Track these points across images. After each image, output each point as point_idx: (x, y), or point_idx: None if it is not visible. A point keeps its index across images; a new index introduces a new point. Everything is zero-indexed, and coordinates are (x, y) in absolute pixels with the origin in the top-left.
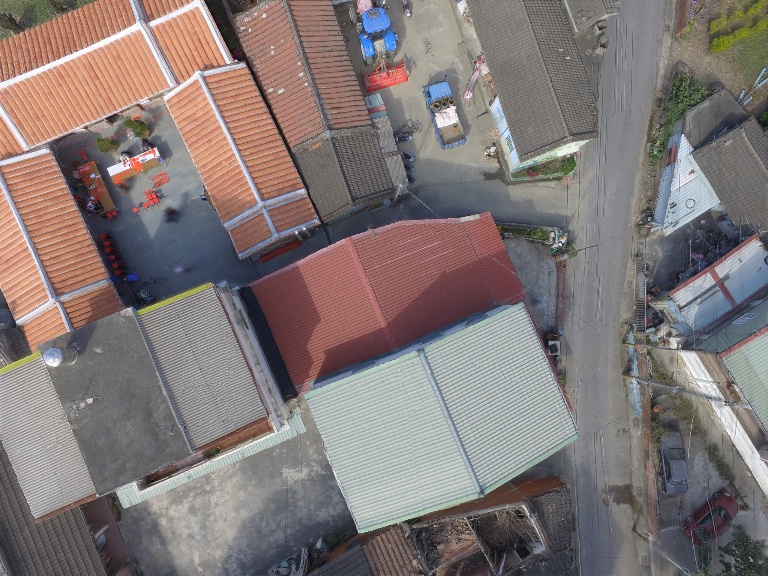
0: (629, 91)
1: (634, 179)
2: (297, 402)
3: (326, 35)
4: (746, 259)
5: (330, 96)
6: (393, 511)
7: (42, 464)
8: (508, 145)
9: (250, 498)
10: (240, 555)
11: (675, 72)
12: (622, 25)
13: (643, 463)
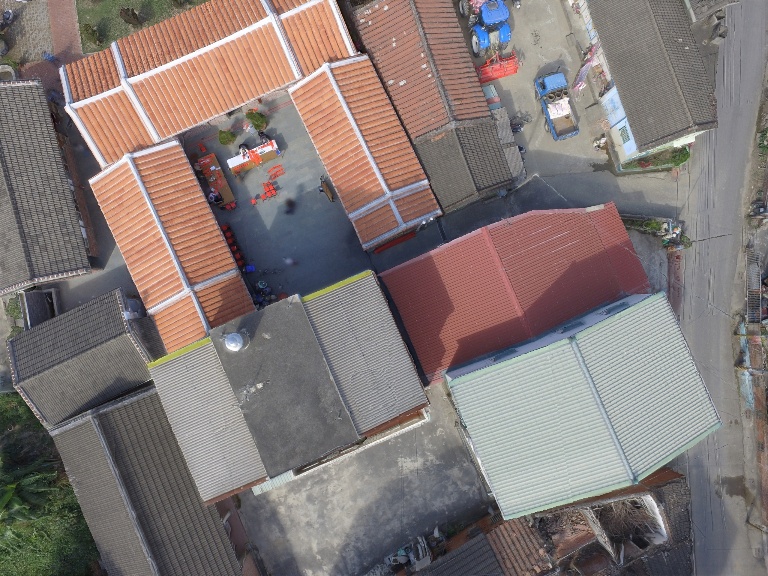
0: (738, 82)
1: (744, 170)
2: (427, 391)
3: (446, 27)
4: None
5: (452, 87)
6: (541, 498)
7: (211, 448)
8: (621, 136)
9: (367, 487)
10: (357, 543)
11: None
12: (730, 15)
13: (756, 455)
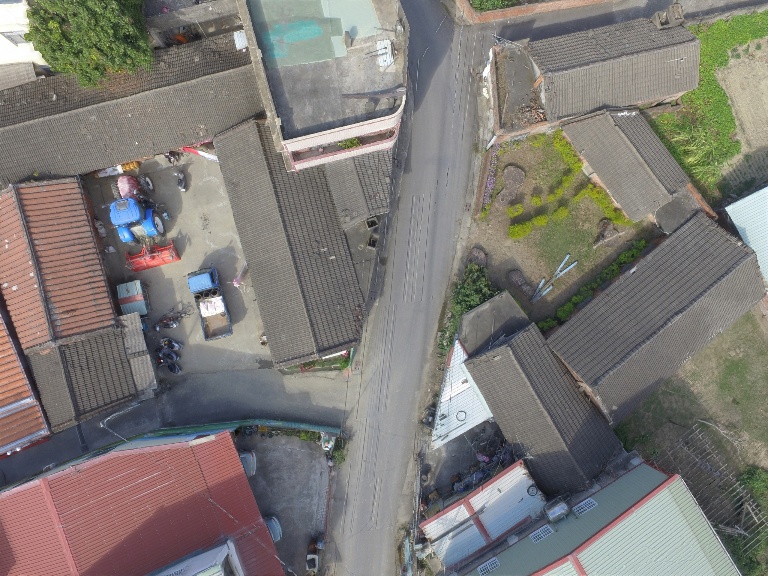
0: (421, 275)
1: (421, 371)
2: None
3: (68, 228)
4: (506, 489)
5: (63, 298)
6: None
7: None
8: None
9: None
10: None
11: (469, 259)
12: (418, 203)
13: None
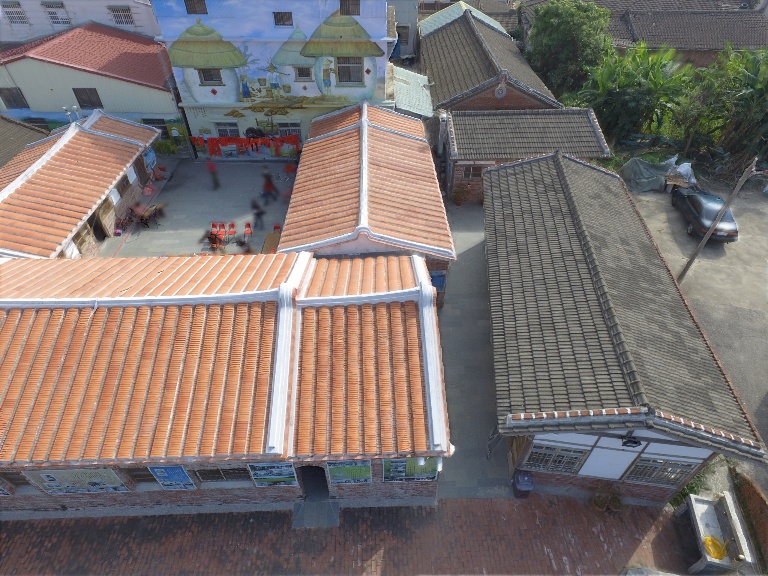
0: None
1: None
2: None
3: None
4: None
5: None
6: None
7: None
8: None
9: None
10: None
11: None
12: None
13: None
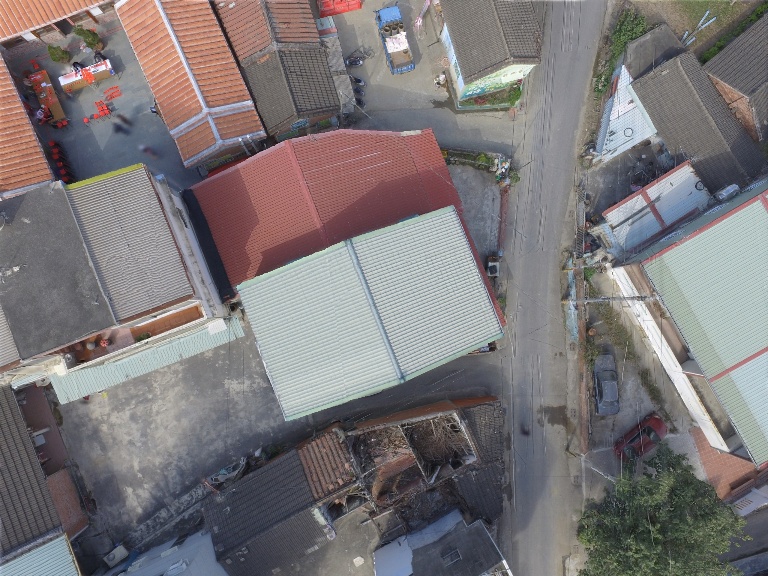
0: (577, 28)
1: (579, 113)
2: (235, 304)
3: None
4: (677, 184)
5: (279, 11)
6: (318, 399)
7: None
8: (456, 72)
9: (192, 407)
10: (180, 462)
11: (621, 10)
12: None
13: (578, 386)
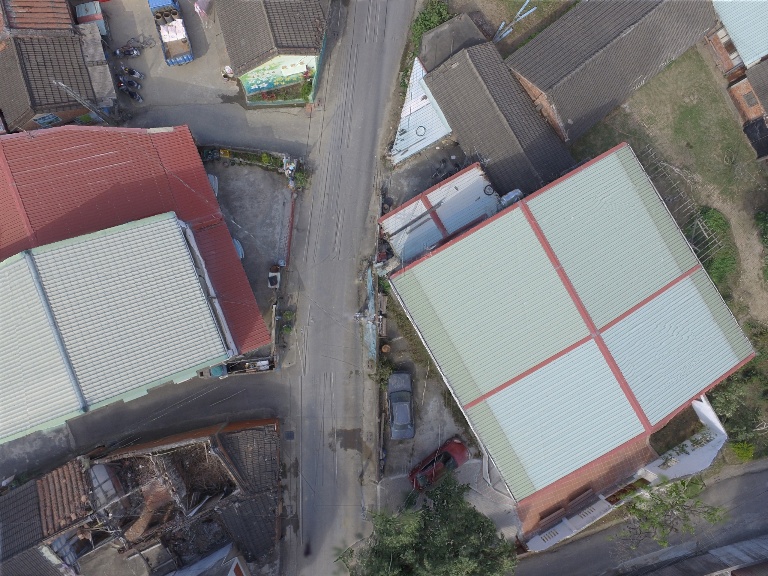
0: (383, 17)
1: (383, 109)
2: None
3: None
4: (463, 188)
5: None
6: (2, 429)
7: None
8: None
9: None
10: None
11: None
12: None
13: (375, 407)
